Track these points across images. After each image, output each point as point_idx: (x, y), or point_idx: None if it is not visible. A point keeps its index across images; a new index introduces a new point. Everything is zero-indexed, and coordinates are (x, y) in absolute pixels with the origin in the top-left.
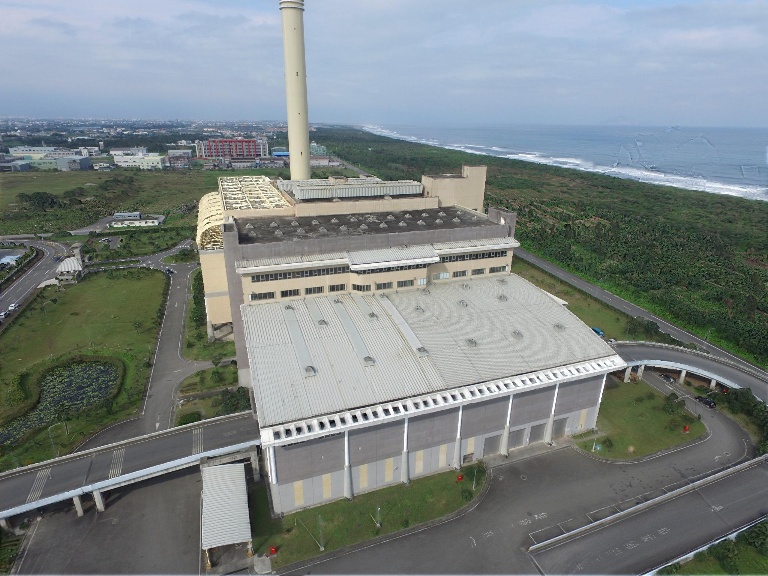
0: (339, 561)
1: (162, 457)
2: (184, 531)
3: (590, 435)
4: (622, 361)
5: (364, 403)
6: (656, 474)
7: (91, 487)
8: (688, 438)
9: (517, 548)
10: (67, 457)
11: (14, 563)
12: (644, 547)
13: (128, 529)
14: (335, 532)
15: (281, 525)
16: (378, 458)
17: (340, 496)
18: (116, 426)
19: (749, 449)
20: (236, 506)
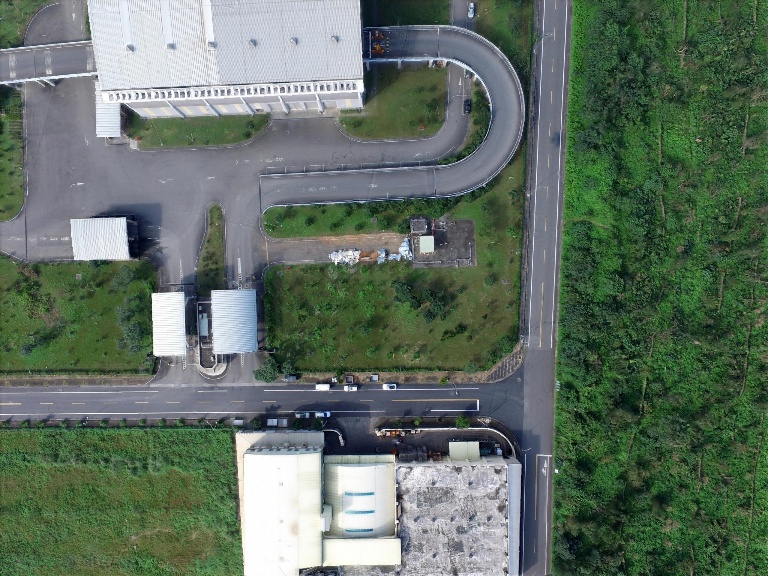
0: (169, 153)
1: (71, 66)
2: None
3: (353, 113)
4: (362, 87)
5: (163, 85)
6: (367, 154)
7: None
8: (417, 135)
9: (256, 173)
10: (19, 48)
11: (22, 108)
12: (316, 192)
13: (70, 103)
14: (170, 137)
15: (144, 124)
16: (191, 105)
17: (178, 115)
18: (47, 9)
19: (447, 155)
20: (113, 115)
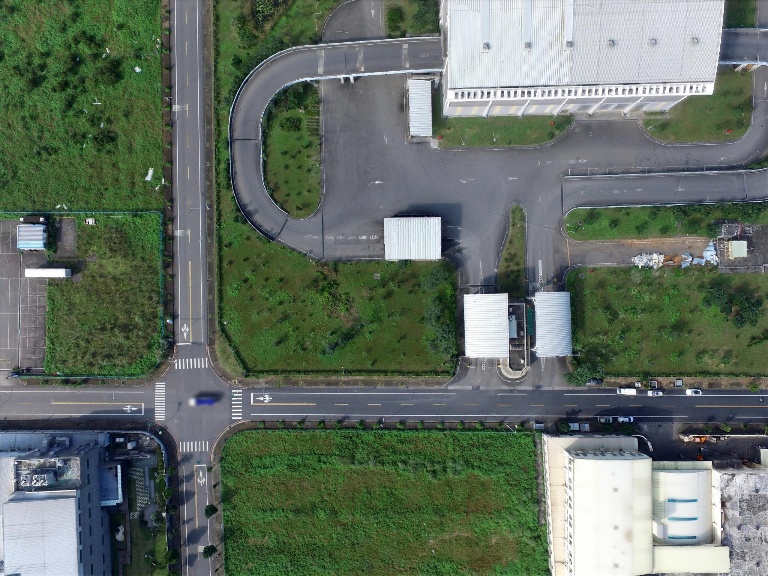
0: (470, 153)
1: (385, 64)
2: (397, 111)
3: (658, 115)
4: (712, 90)
5: (512, 84)
6: (671, 157)
7: (350, 75)
8: (722, 138)
9: (558, 174)
10: (331, 44)
11: (320, 104)
12: (621, 195)
13: (368, 100)
14: (472, 137)
15: (445, 123)
16: (509, 105)
17: (480, 114)
18: (345, 5)
19: (752, 159)
20: (426, 113)
